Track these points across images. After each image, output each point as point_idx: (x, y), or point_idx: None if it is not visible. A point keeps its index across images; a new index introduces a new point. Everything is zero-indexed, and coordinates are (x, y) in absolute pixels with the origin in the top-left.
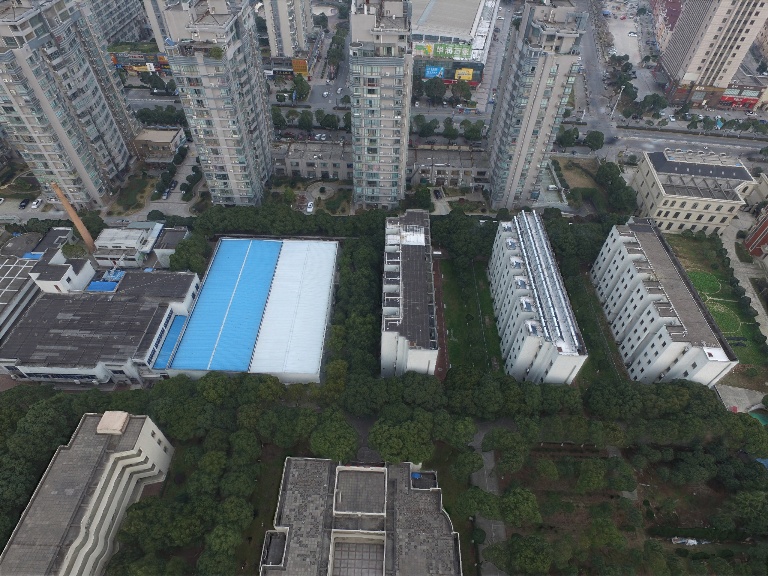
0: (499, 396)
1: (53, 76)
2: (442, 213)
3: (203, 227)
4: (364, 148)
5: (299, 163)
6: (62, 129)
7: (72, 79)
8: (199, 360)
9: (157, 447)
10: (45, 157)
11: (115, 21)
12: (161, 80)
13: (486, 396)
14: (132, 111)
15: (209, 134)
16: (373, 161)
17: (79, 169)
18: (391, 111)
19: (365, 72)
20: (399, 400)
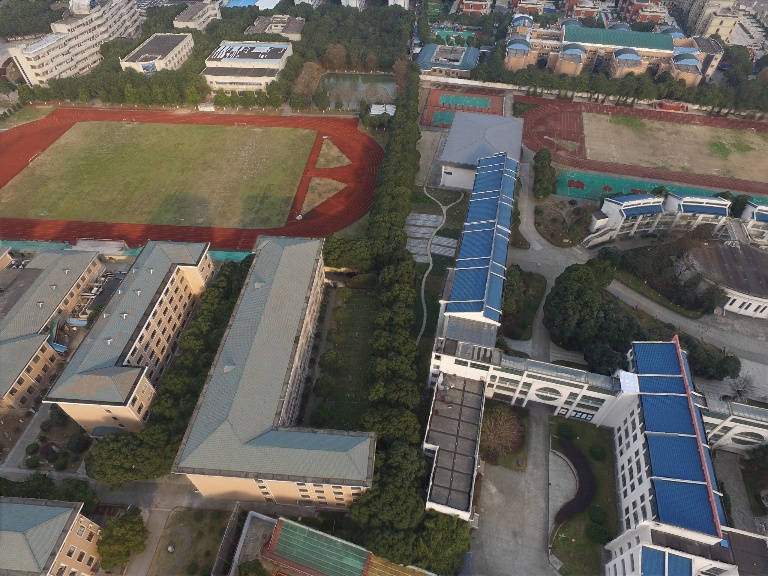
0: (329, 5)
1: None
2: None
3: None
4: None
5: None
6: None
7: None
8: None
9: (219, 17)
10: None
11: None
12: None
13: (326, 6)
14: None
15: None
16: None
17: None
18: None
19: None
20: None
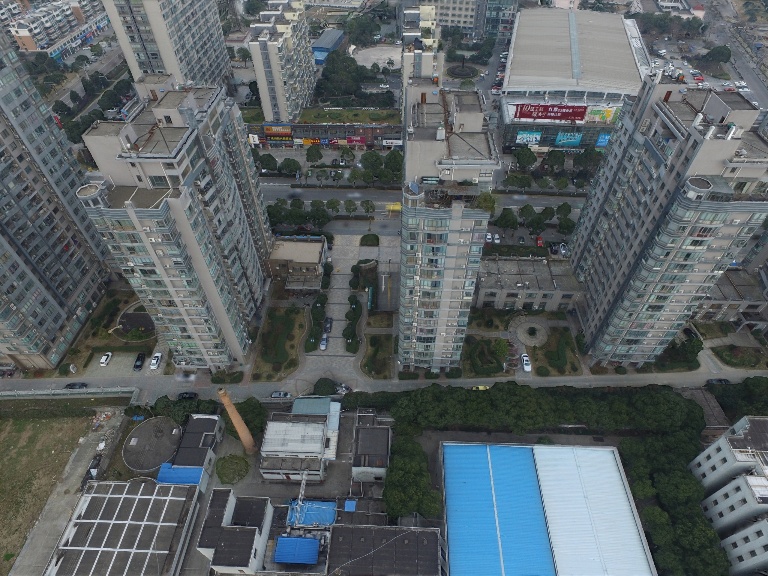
0: None
1: (203, 214)
2: (712, 370)
3: (408, 419)
4: (643, 304)
5: (497, 293)
6: (214, 287)
7: (222, 211)
8: None
9: None
10: (185, 321)
11: (207, 82)
12: (274, 159)
13: None
14: (268, 223)
15: (430, 296)
16: (649, 319)
17: (224, 328)
18: (711, 264)
19: (701, 220)
20: None
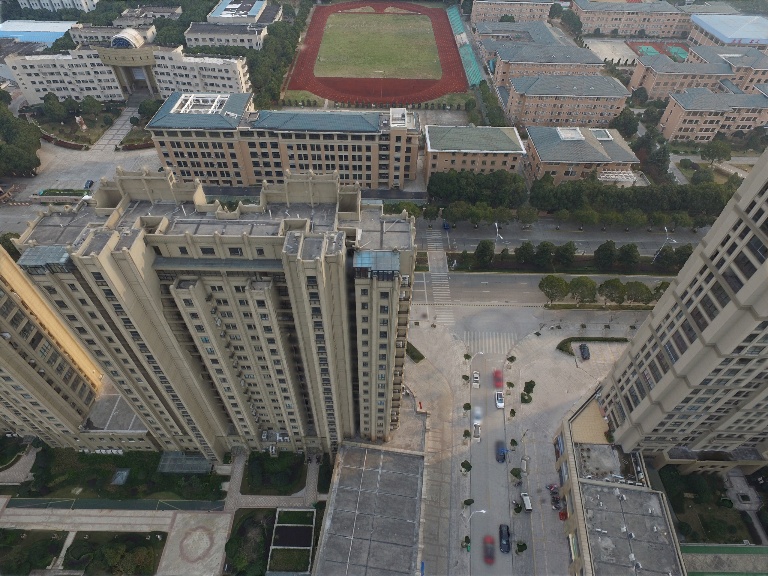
0: None
1: None
2: None
3: None
4: None
5: None
6: None
7: None
8: (55, 38)
9: None
10: None
11: None
12: None
13: None
14: None
15: None
16: None
17: None
18: None
19: None
20: (106, 8)
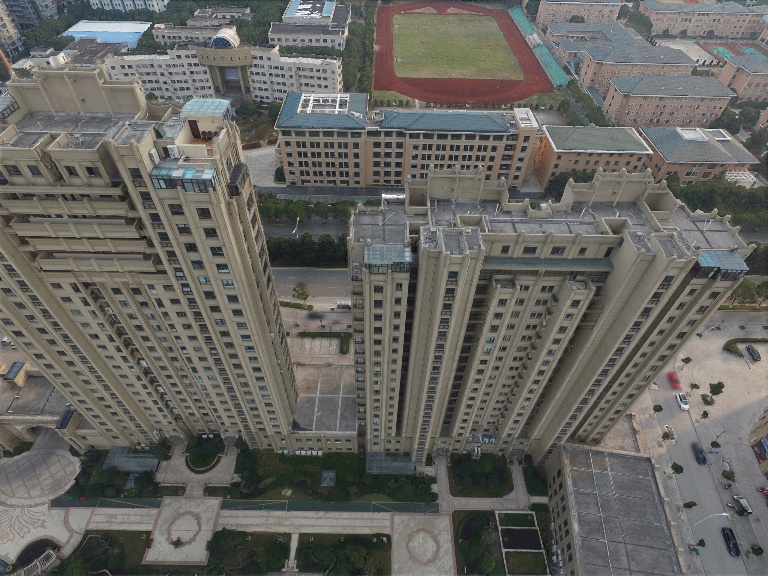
0: None
1: None
2: None
3: None
4: None
5: None
6: None
7: None
8: None
9: None
10: None
11: None
12: None
13: None
14: None
15: None
16: None
17: None
18: None
19: None
20: (176, 8)
